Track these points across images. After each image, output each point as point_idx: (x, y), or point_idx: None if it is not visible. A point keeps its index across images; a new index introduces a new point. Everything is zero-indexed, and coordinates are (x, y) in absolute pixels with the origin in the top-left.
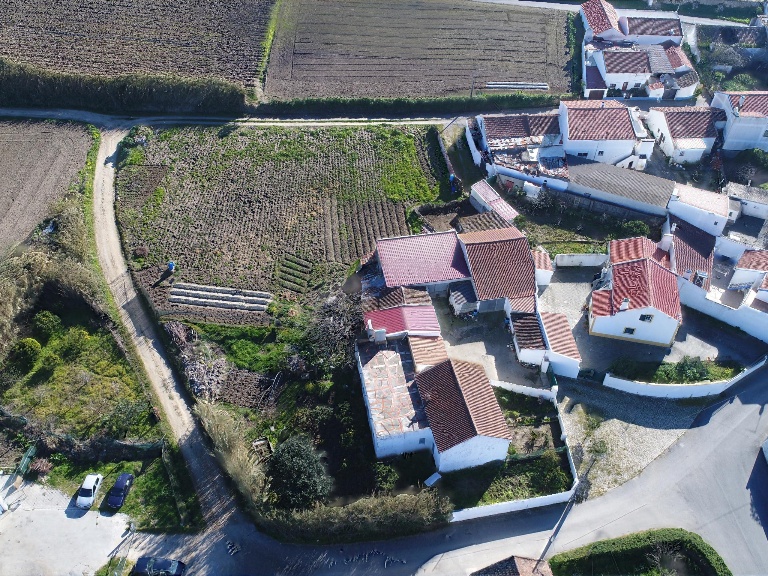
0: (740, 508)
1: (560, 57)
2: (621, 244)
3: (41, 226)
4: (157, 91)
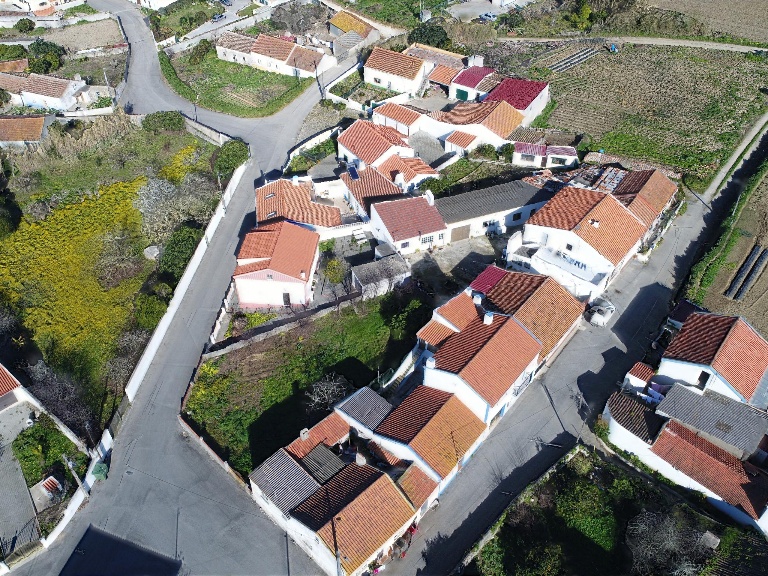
0: (248, 136)
1: None
2: (429, 171)
3: None
4: None
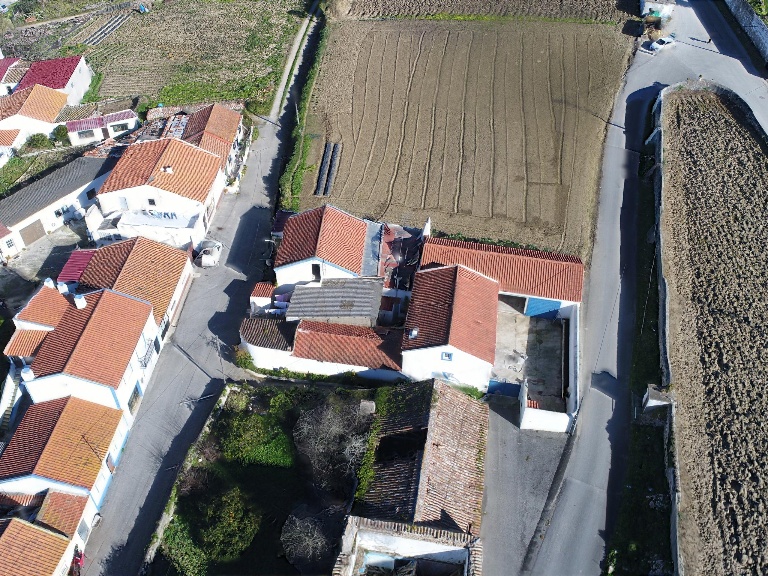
0: None
1: (407, 221)
2: None
3: None
4: None
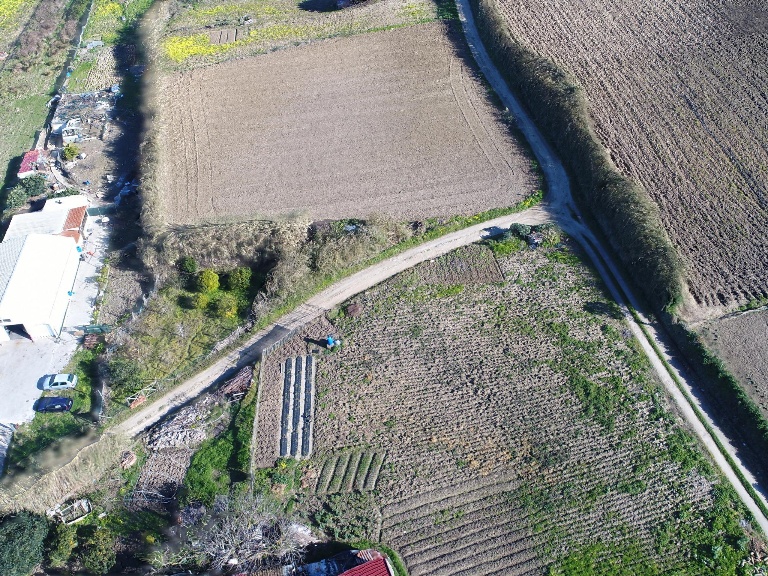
0: None
1: None
2: None
3: (352, 221)
4: (619, 213)
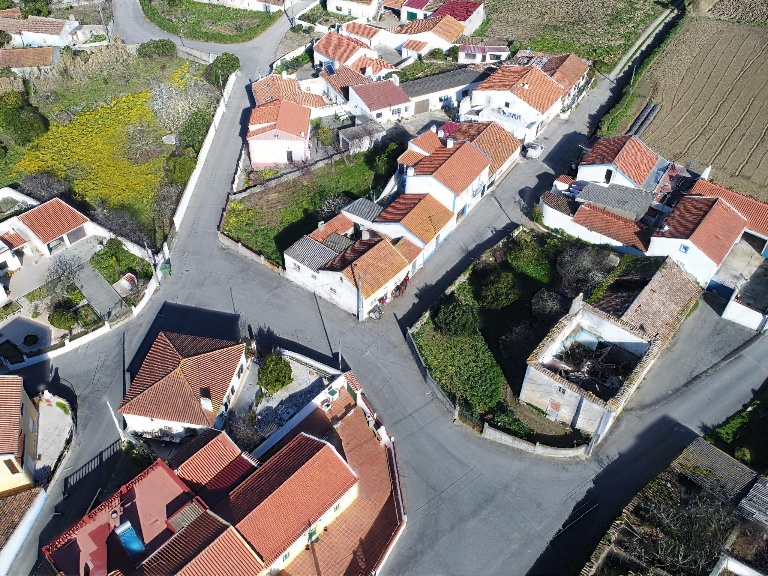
0: None
1: None
2: None
3: None
4: None
